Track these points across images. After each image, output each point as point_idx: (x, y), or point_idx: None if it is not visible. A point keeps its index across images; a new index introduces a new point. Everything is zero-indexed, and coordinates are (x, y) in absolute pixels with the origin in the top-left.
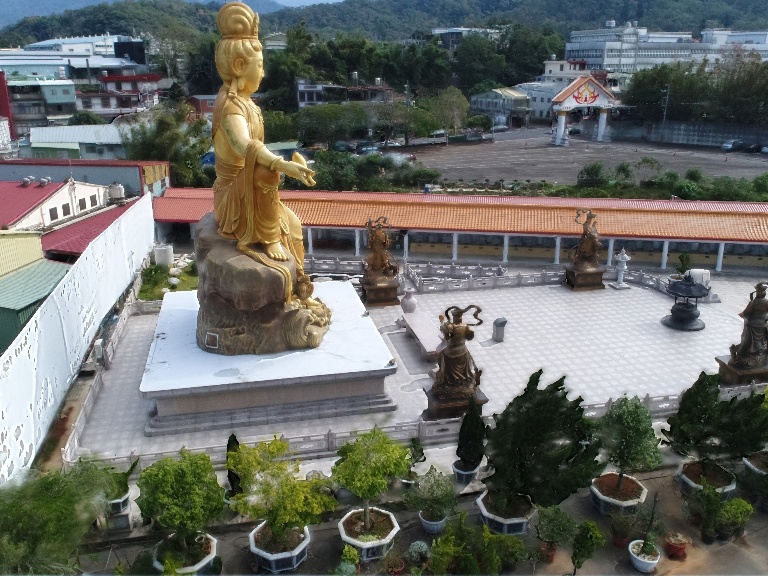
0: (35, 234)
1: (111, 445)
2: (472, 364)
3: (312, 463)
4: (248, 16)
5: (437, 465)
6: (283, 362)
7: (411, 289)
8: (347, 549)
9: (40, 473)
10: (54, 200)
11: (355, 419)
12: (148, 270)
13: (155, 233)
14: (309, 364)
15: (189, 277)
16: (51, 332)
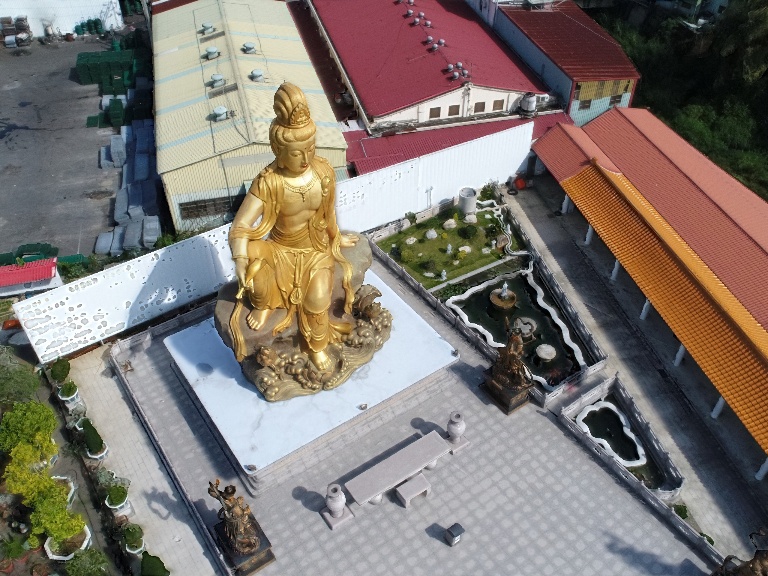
0: (338, 148)
1: (157, 353)
2: (236, 533)
3: (162, 472)
4: (287, 105)
5: (177, 559)
6: (233, 393)
7: (456, 418)
8: (32, 537)
9: (8, 362)
10: (440, 101)
11: (229, 474)
12: (412, 215)
13: (528, 161)
14: (235, 411)
15: (455, 236)
16: (187, 259)
